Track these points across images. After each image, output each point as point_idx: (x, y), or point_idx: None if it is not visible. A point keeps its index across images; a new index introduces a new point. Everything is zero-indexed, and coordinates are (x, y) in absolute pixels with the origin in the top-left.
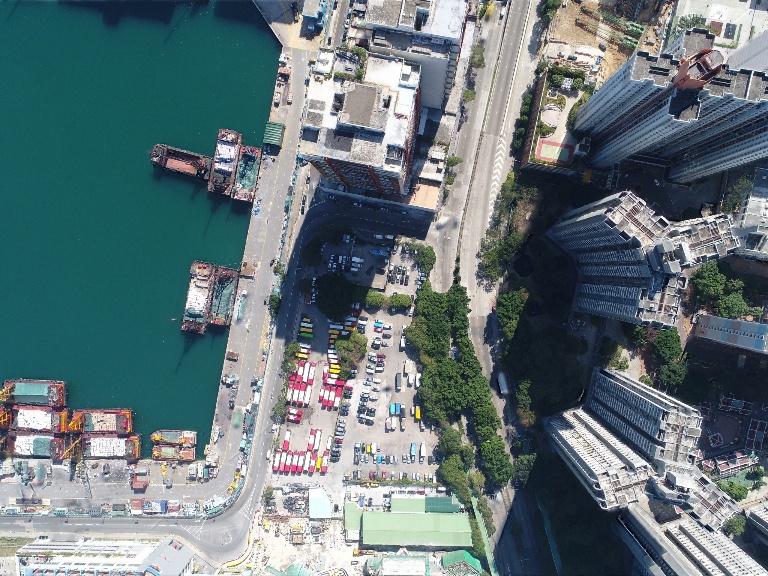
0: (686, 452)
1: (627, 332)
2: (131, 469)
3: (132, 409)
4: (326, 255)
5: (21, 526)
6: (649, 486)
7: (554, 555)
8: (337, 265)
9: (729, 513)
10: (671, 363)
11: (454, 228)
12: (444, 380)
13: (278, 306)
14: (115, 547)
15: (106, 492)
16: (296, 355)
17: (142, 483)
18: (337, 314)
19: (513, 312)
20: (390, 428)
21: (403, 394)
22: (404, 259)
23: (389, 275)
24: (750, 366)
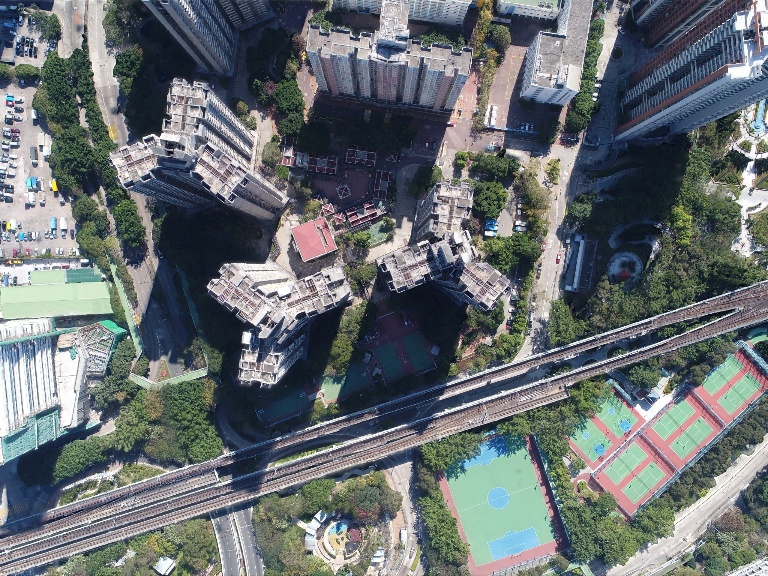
0: (193, 123)
1: (249, 88)
2: None
3: None
4: None
5: None
6: None
7: (193, 315)
8: None
9: (239, 181)
10: (290, 114)
11: None
12: (67, 142)
13: None
14: None
15: None
16: None
17: None
18: None
19: (131, 70)
20: (28, 203)
21: (41, 169)
22: (32, 31)
23: (17, 47)
24: None
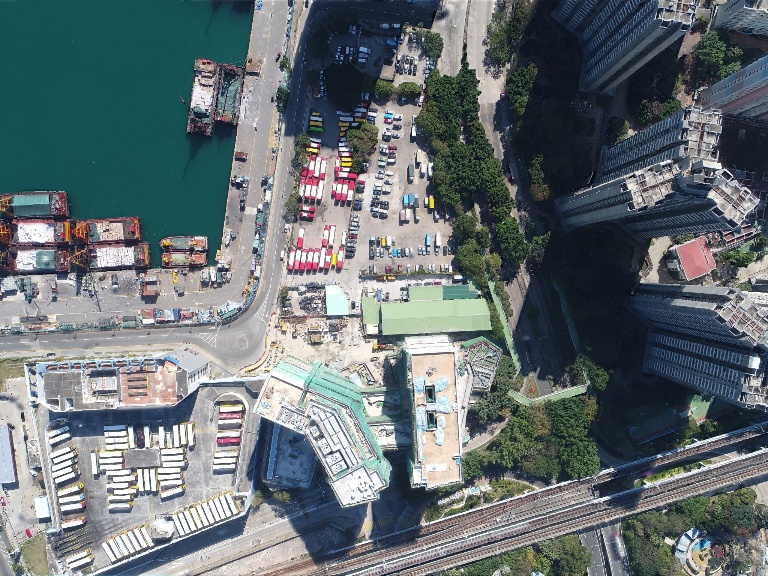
0: (708, 149)
1: (633, 108)
2: (141, 277)
3: (139, 217)
4: (333, 48)
5: (26, 345)
6: (674, 185)
7: (571, 332)
8: (344, 57)
9: (751, 207)
10: None
11: (460, 16)
12: (458, 161)
13: (286, 99)
14: (129, 353)
15: (115, 304)
16: (307, 150)
17: (153, 290)
18: (348, 100)
19: (523, 89)
20: (404, 219)
21: (416, 186)
22: (411, 49)
23: (397, 65)
24: (750, 139)
